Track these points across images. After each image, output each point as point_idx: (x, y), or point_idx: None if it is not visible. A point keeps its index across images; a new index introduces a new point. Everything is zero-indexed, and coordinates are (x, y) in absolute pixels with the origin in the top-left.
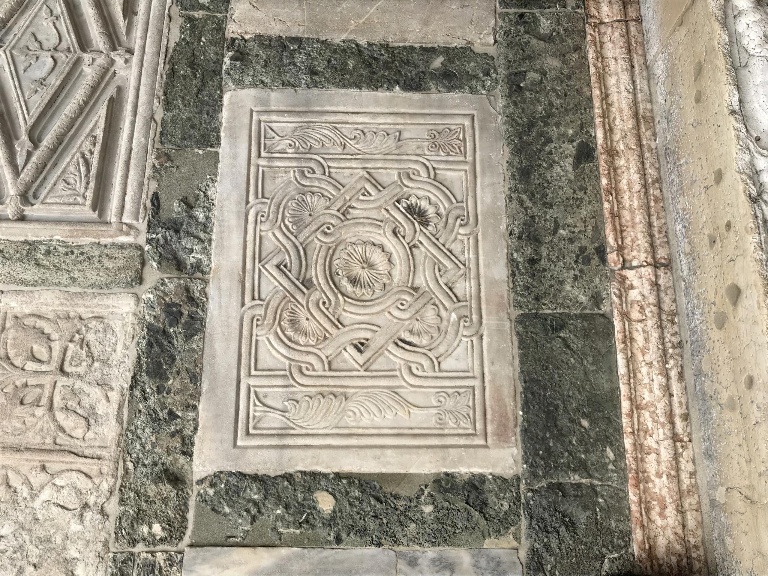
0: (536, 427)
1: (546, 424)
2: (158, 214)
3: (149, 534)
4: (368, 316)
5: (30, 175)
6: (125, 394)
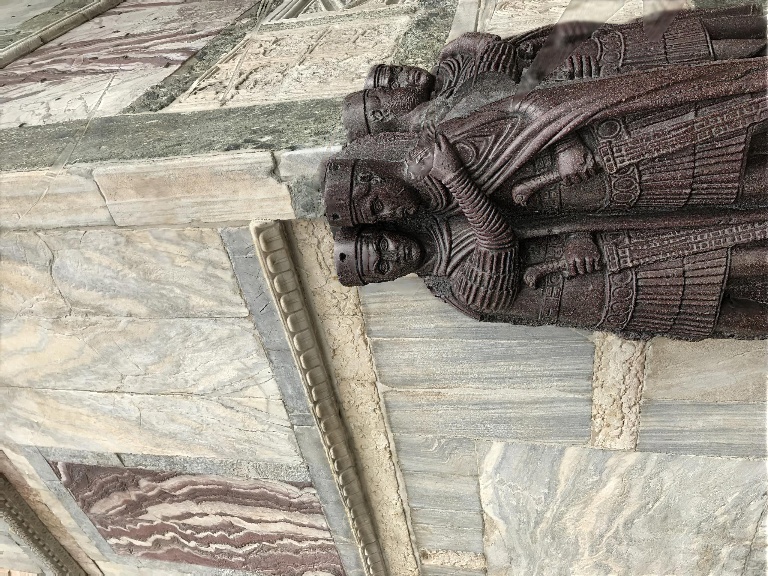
0: (708, 7)
1: (716, 4)
2: (425, 0)
3: (413, 61)
4: (566, 0)
5: (352, 3)
6: (401, 37)
